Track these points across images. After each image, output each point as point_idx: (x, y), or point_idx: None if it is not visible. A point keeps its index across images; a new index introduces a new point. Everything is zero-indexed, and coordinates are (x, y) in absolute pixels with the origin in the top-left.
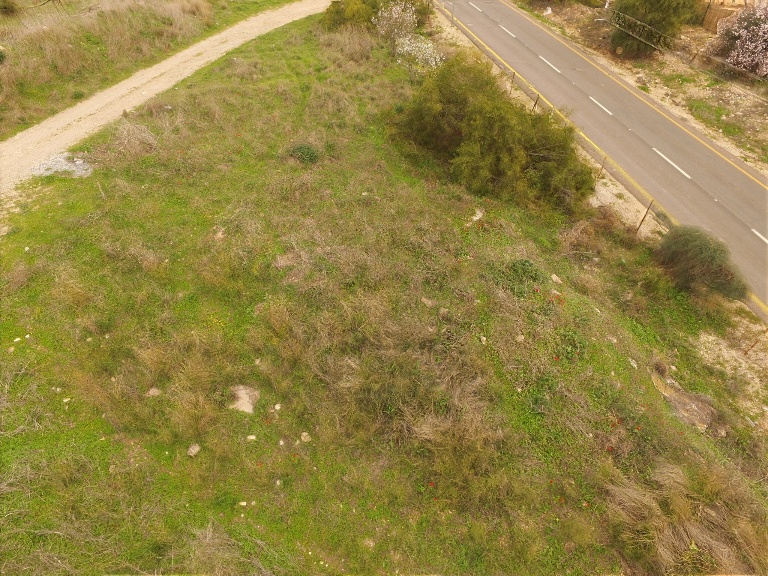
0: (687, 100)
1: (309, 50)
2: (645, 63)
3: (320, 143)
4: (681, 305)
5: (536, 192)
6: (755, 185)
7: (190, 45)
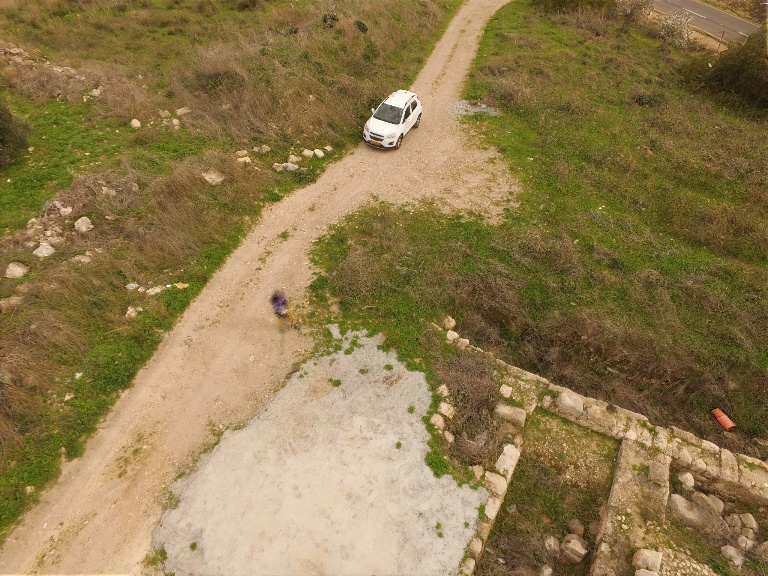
0: None
1: (550, 28)
2: None
3: (650, 93)
4: None
5: None
6: None
7: (447, 24)
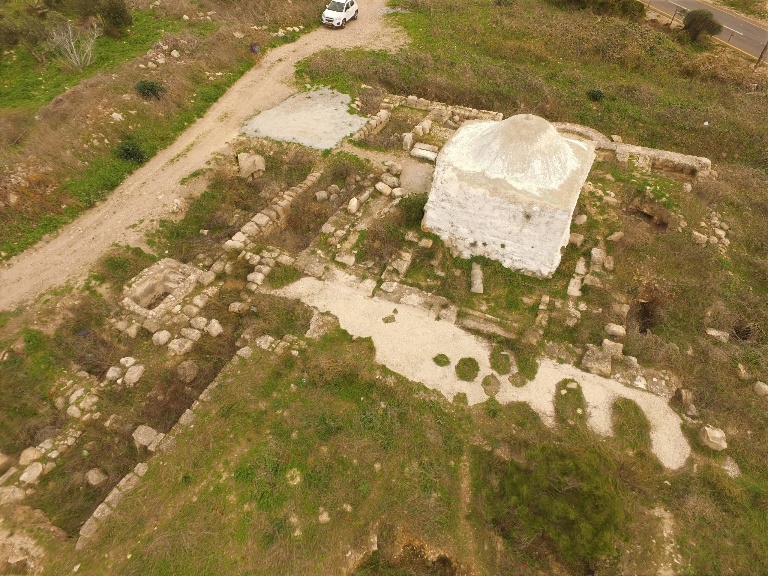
0: None
1: None
2: None
3: None
4: (694, 46)
5: (622, 12)
6: (721, 12)
7: None
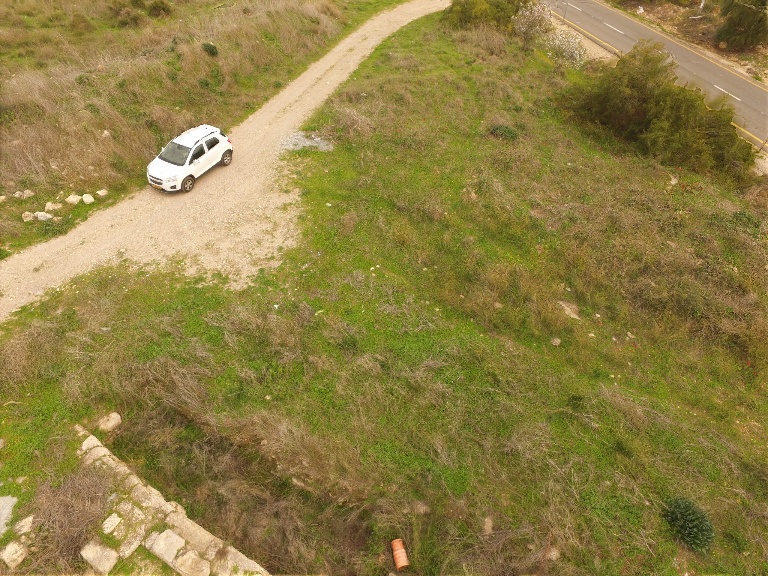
0: None
1: (447, 46)
2: (750, 56)
3: (511, 123)
4: None
5: (714, 162)
6: None
7: (338, 42)
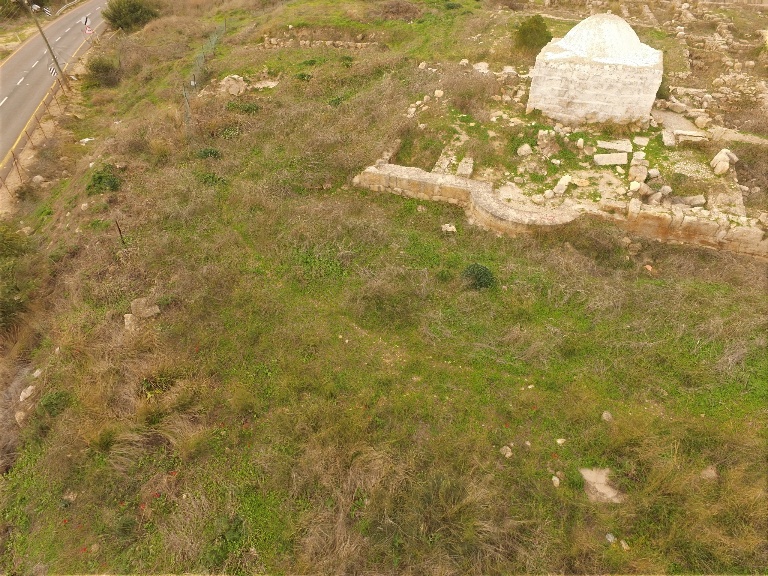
0: None
1: None
2: None
3: None
4: None
5: None
6: None
7: None
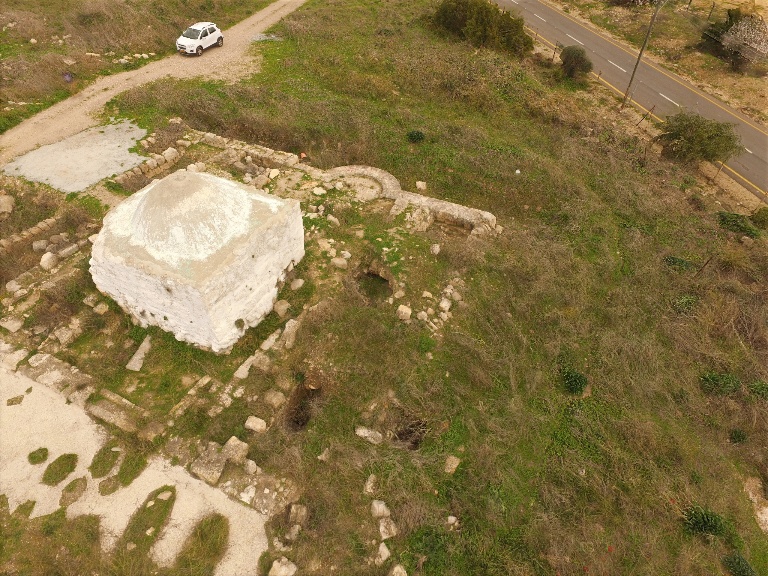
0: (590, 16)
1: None
2: None
3: (392, 29)
4: (569, 82)
5: (504, 45)
6: (615, 47)
7: None
